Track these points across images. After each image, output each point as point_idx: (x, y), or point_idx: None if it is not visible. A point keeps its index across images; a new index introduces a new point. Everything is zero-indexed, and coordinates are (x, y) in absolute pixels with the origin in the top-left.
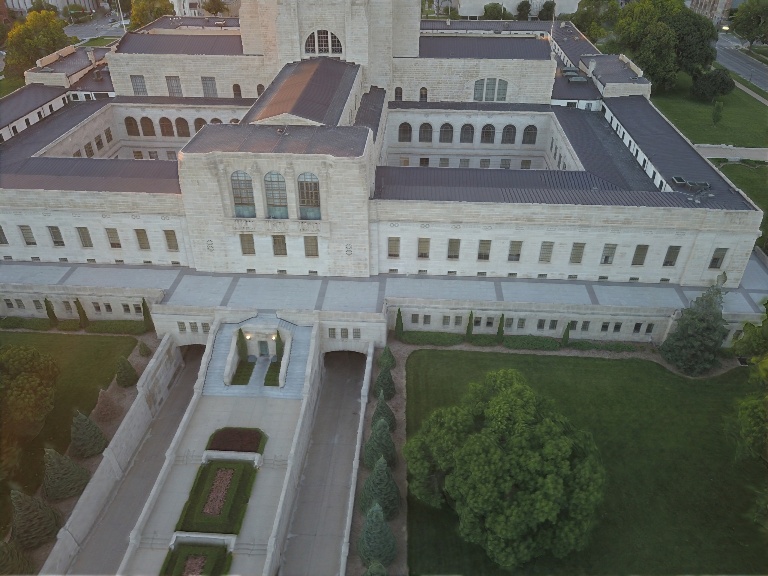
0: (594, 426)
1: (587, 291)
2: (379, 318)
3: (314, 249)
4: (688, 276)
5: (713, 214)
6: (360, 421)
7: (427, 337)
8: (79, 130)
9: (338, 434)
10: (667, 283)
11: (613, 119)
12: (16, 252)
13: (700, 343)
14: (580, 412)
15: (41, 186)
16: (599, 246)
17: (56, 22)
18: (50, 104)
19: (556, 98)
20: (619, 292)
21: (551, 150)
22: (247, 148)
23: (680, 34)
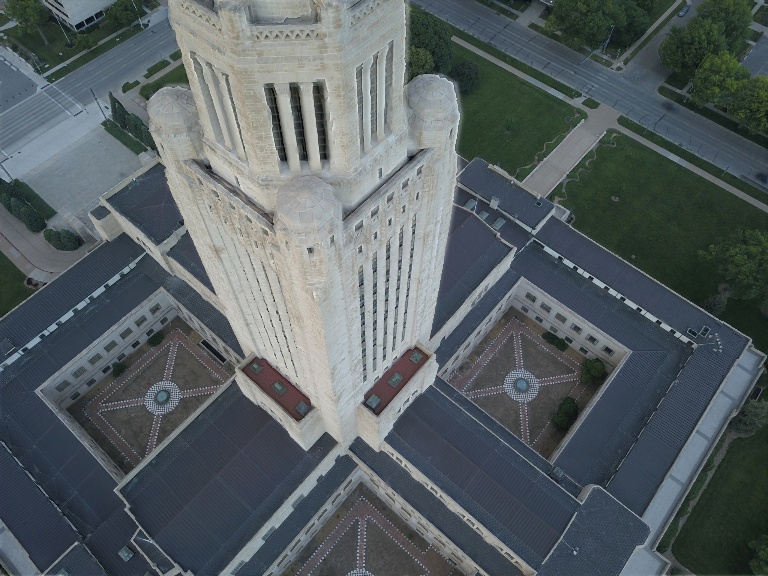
0: (764, 508)
1: None
2: None
3: None
4: None
5: None
6: None
7: (669, 537)
8: None
9: None
10: None
11: (565, 260)
12: None
13: None
14: (753, 506)
15: None
16: None
17: None
18: None
19: None
20: (704, 418)
21: (528, 298)
22: None
23: (431, 50)
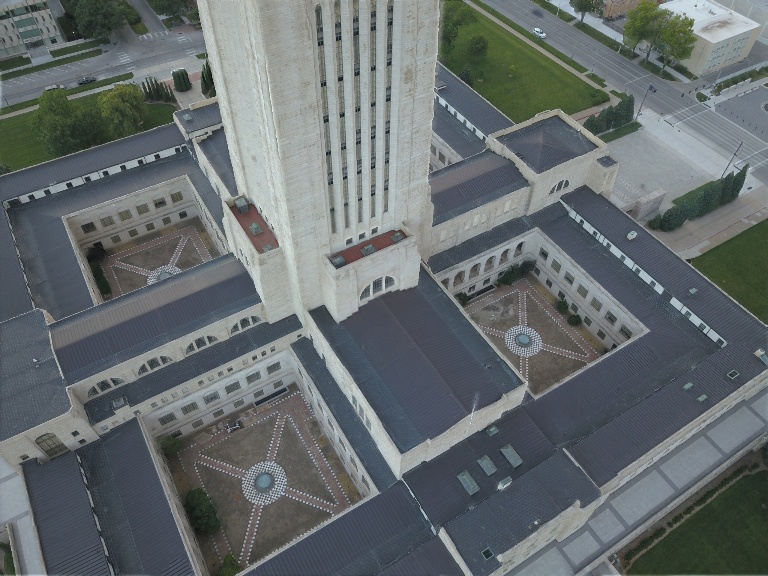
0: None
1: None
2: None
3: None
4: None
5: None
6: None
7: (10, 571)
8: (128, 198)
9: None
10: None
11: None
12: None
13: None
14: None
15: None
16: None
17: None
18: (157, 154)
19: (406, 481)
20: None
21: None
22: None
23: None
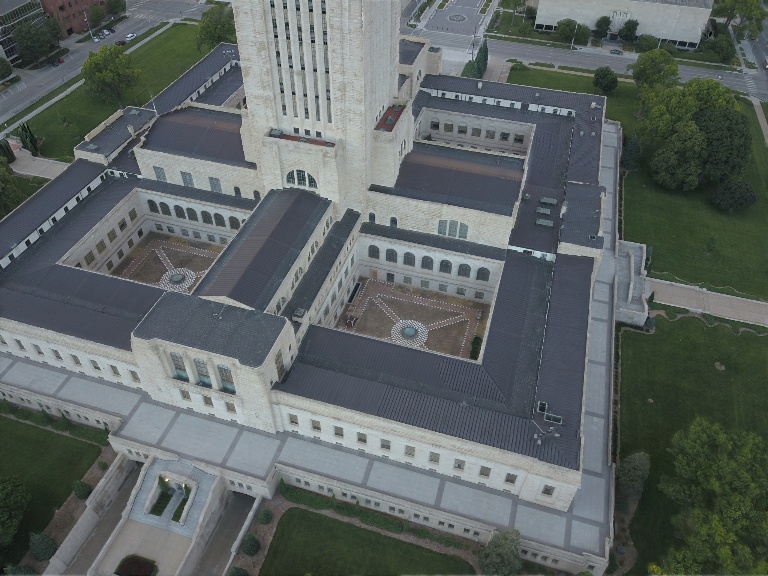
0: None
1: (438, 487)
2: (263, 484)
3: (234, 408)
4: (524, 494)
5: (539, 465)
6: (224, 572)
7: (303, 498)
8: (102, 225)
9: (219, 564)
10: (509, 493)
11: None
12: (32, 356)
13: (495, 570)
14: None
15: (47, 319)
16: (450, 458)
17: (122, 57)
18: (88, 186)
19: (513, 245)
20: (464, 494)
21: None
22: (182, 336)
23: (709, 138)
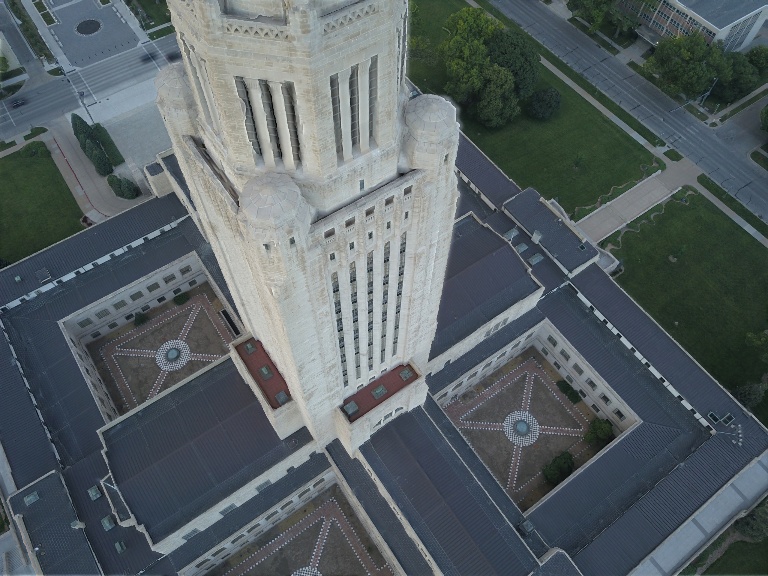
0: None
1: (693, 523)
2: None
3: None
4: None
5: None
6: None
7: None
8: None
9: None
10: None
11: (597, 311)
12: None
13: None
14: None
15: None
16: None
17: None
18: None
19: None
20: (707, 510)
21: (550, 341)
22: None
23: (514, 70)
